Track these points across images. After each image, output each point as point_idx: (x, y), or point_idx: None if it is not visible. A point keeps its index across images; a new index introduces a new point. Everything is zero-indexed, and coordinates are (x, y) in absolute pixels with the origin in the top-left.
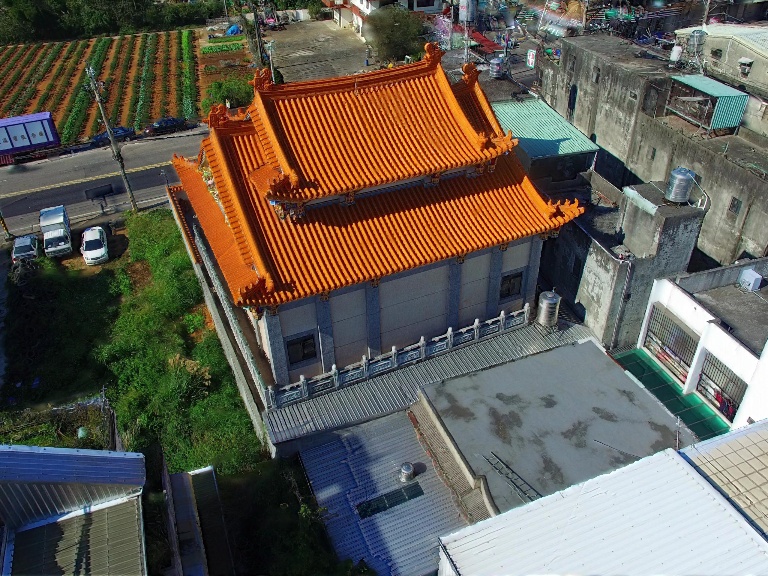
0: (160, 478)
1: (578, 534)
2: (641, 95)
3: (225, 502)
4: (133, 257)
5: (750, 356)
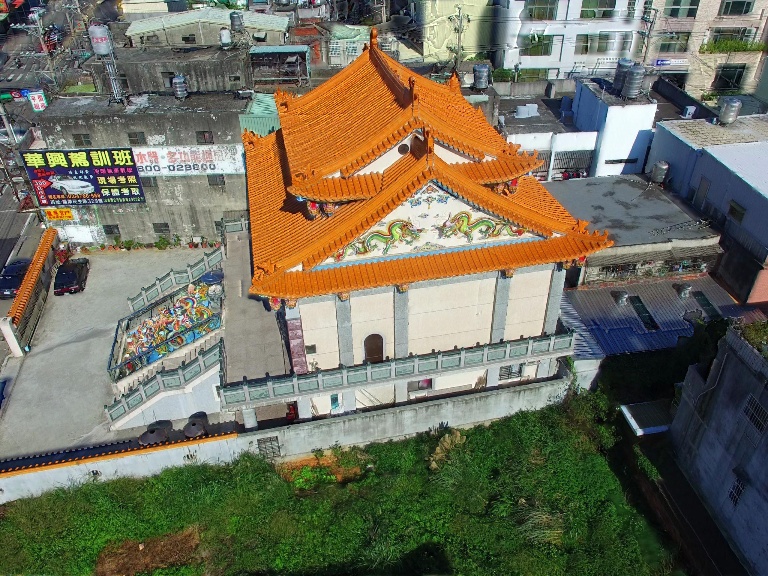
0: None
1: (767, 178)
2: (246, 74)
3: None
4: (88, 567)
5: None
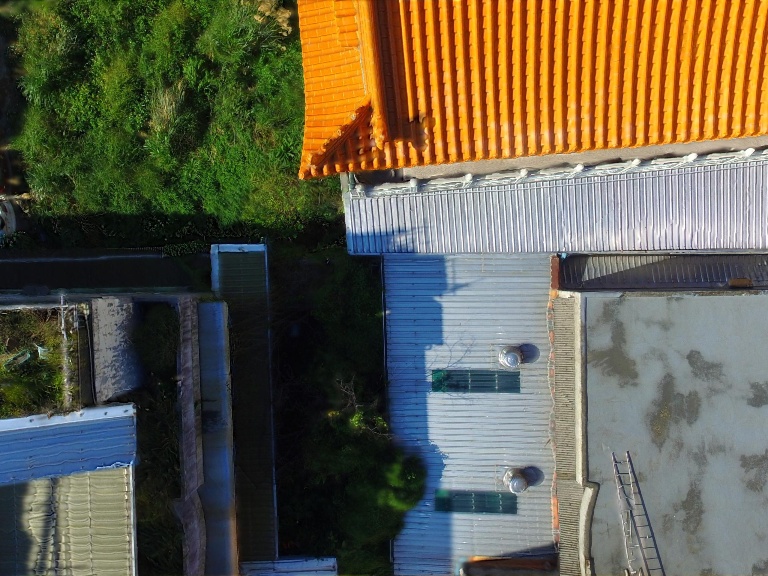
0: (174, 360)
1: None
2: None
3: (275, 304)
4: None
5: None
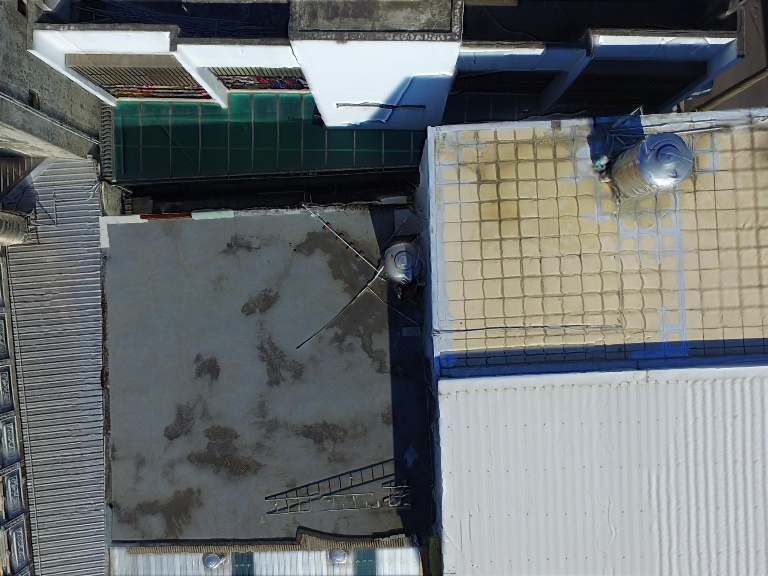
0: None
1: None
2: None
3: None
4: None
5: (268, 49)
